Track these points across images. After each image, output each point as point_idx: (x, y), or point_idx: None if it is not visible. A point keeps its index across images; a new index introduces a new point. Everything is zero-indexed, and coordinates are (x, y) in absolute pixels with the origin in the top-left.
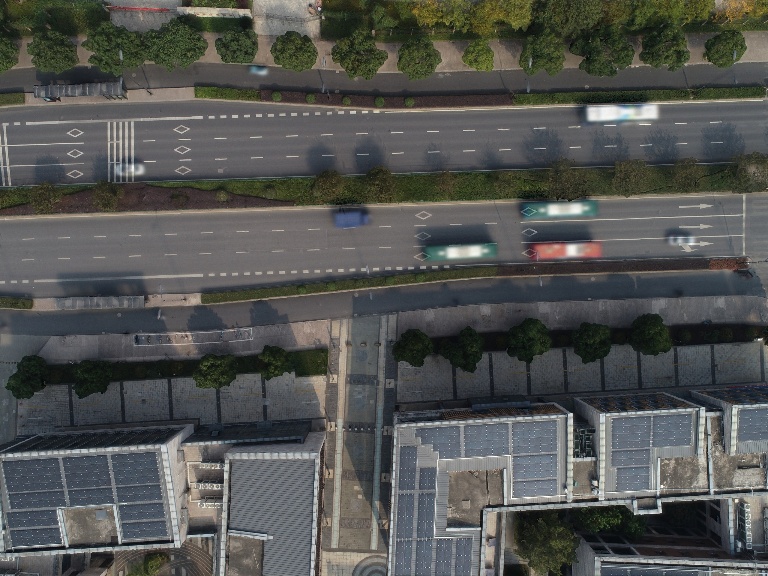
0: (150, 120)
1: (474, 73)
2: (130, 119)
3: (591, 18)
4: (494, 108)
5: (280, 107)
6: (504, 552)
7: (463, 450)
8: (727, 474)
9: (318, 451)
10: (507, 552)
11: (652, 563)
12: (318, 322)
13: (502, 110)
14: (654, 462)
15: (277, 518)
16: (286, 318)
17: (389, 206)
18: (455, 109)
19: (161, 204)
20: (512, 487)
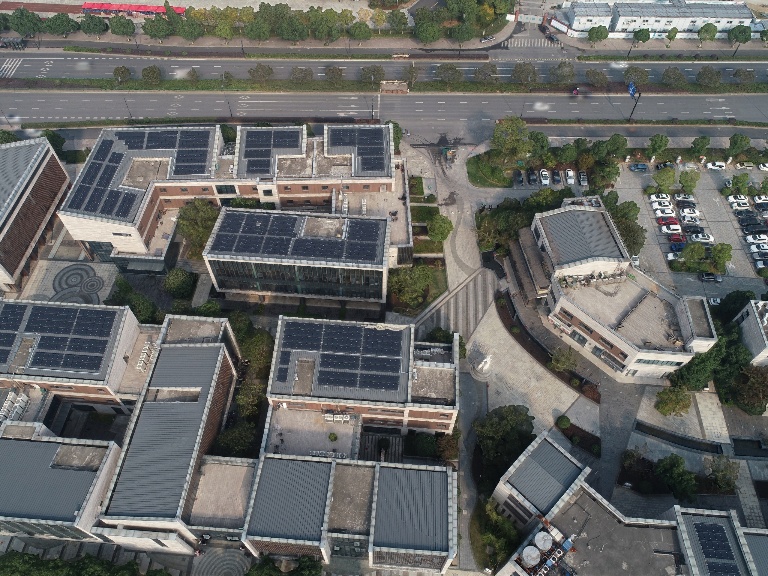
0: (33, 59)
1: (227, 48)
2: (21, 58)
3: (283, 13)
4: (234, 59)
5: (111, 56)
6: (171, 237)
7: (145, 145)
8: (326, 169)
9: (47, 140)
10: (184, 264)
11: (265, 212)
12: (93, 140)
13: (239, 60)
14: (274, 157)
15: (3, 175)
16: (73, 138)
17: (159, 93)
18: (212, 59)
19: (19, 85)
20: (174, 168)
